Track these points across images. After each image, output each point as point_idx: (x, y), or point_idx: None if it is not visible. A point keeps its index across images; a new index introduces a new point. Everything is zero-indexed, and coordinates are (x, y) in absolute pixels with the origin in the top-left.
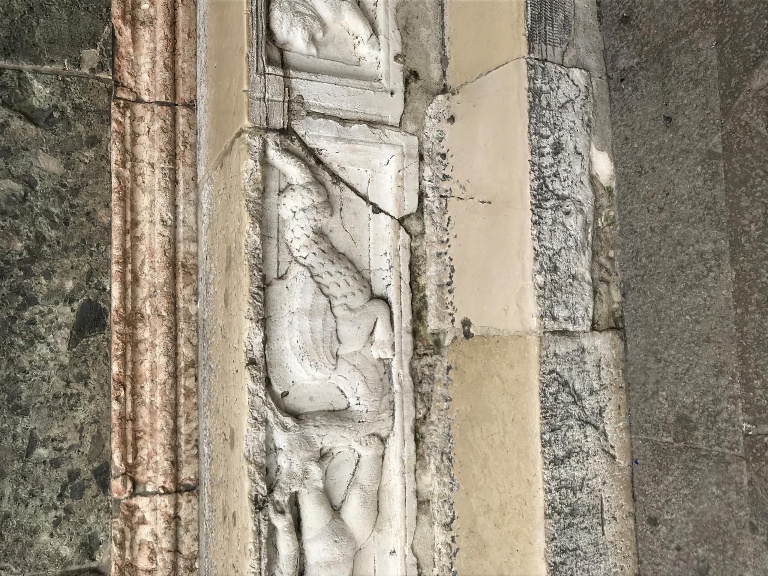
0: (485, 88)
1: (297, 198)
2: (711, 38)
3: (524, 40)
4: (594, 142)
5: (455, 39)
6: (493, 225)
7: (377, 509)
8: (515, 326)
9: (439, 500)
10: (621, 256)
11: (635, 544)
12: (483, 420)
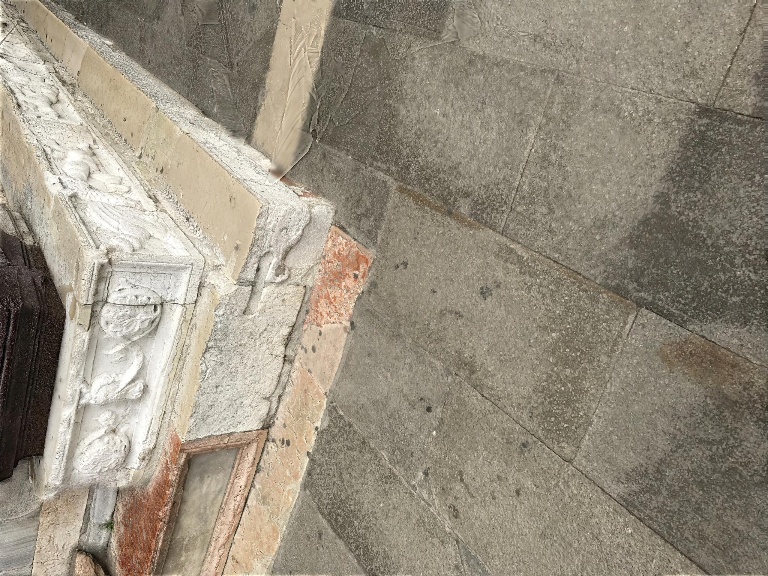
0: (65, 45)
1: (6, 63)
2: (110, 2)
3: (68, 28)
4: (102, 39)
5: (58, 54)
6: (74, 52)
7: (57, 98)
8: (84, 52)
9: (84, 100)
10: (120, 48)
11: (150, 72)
12: (87, 75)
